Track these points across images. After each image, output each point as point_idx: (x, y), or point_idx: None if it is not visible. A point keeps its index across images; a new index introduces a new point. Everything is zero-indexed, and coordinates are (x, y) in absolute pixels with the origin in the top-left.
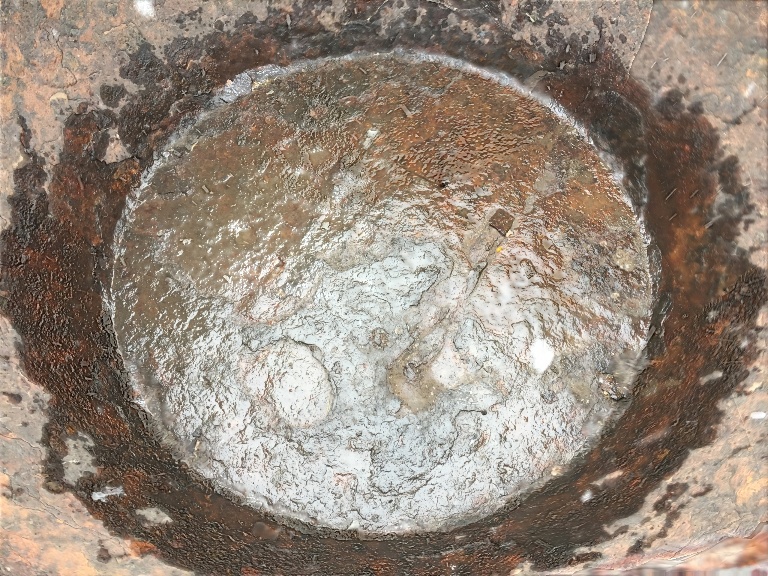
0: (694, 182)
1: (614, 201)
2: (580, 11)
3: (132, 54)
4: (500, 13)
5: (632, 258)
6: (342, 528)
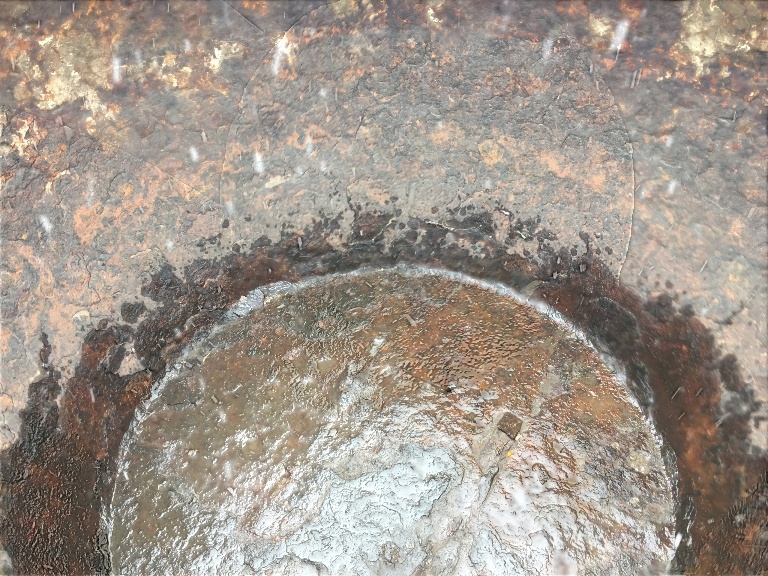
0: (697, 381)
1: (620, 402)
2: (566, 228)
3: (154, 275)
4: (493, 231)
5: (646, 460)
6: None
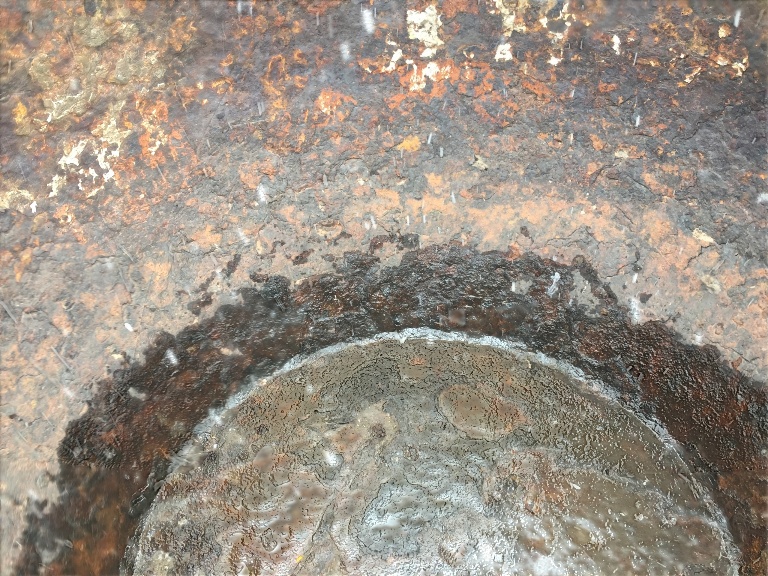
0: None
1: None
2: None
3: None
4: None
5: (152, 567)
6: (411, 339)
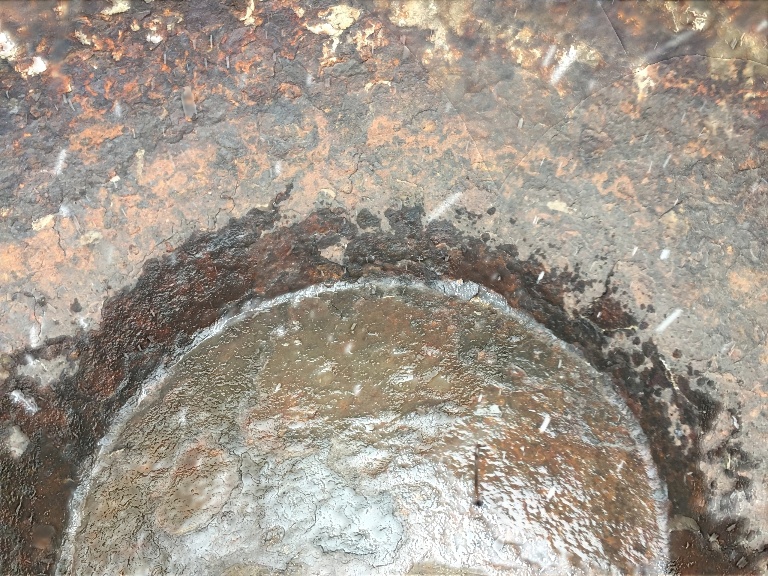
0: None
1: None
2: None
3: (406, 207)
4: (709, 430)
5: None
6: None
